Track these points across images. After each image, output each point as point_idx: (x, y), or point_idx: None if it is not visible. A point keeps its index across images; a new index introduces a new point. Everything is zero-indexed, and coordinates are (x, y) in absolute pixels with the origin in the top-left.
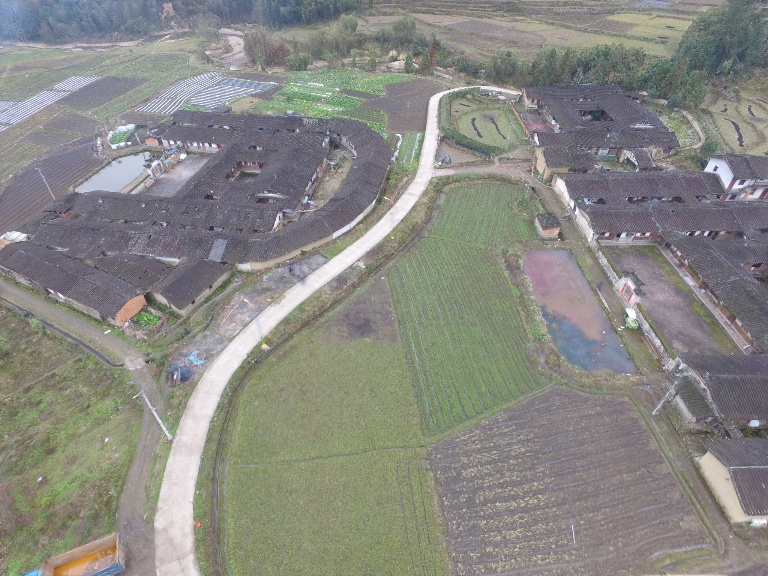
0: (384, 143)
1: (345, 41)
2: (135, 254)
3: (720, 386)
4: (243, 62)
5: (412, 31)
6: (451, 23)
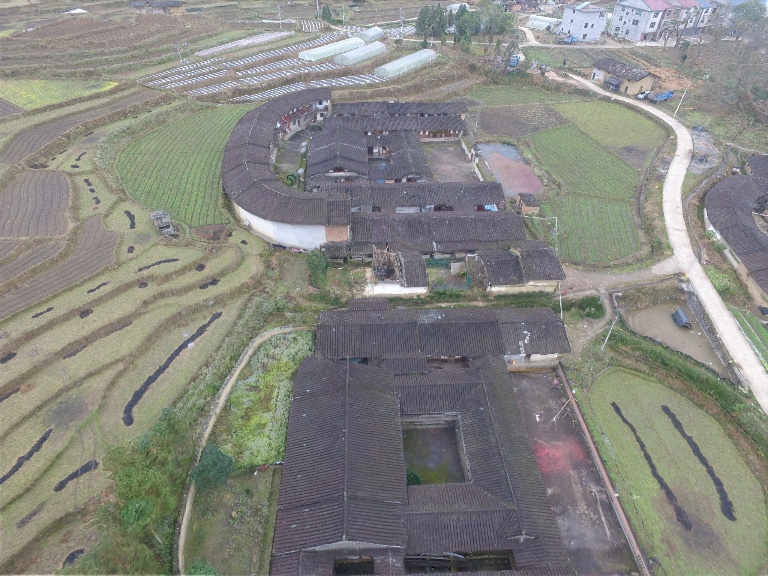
0: None
1: None
2: None
3: None
4: None
5: None
6: None
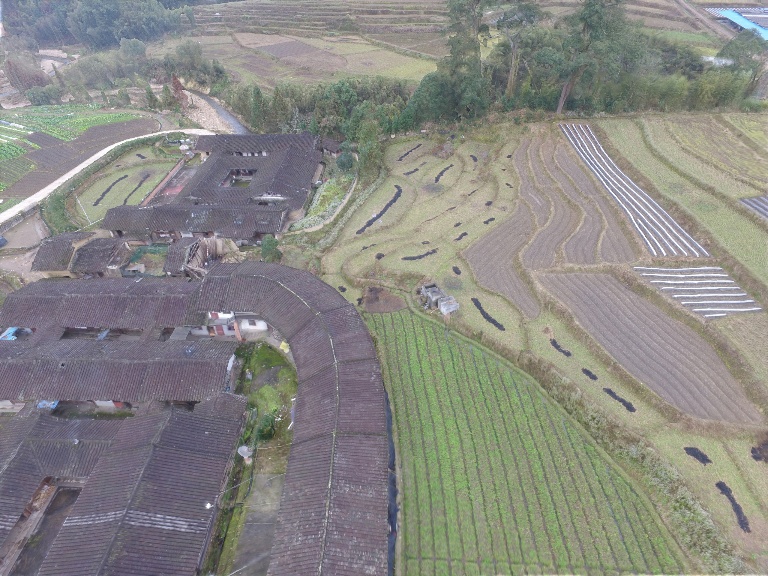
0: None
1: (106, 70)
2: None
3: None
4: (14, 92)
5: (195, 56)
6: (266, 44)
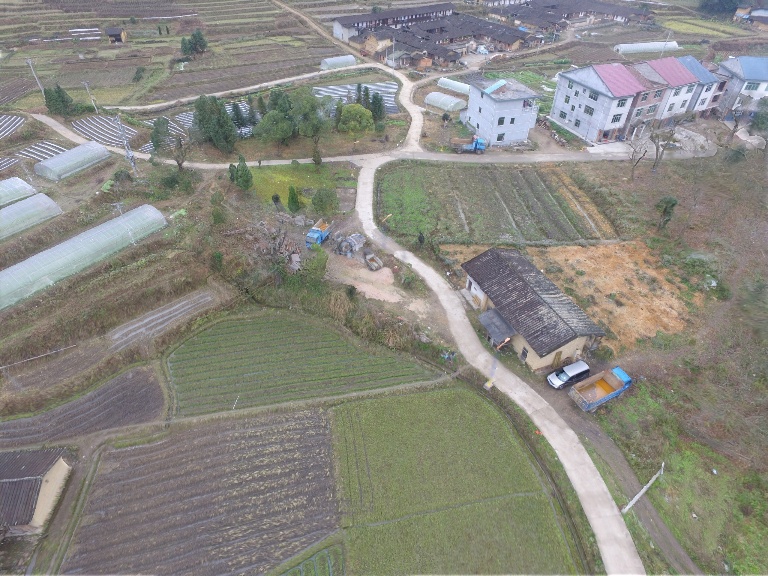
0: None
1: None
2: None
3: None
4: None
5: None
6: None
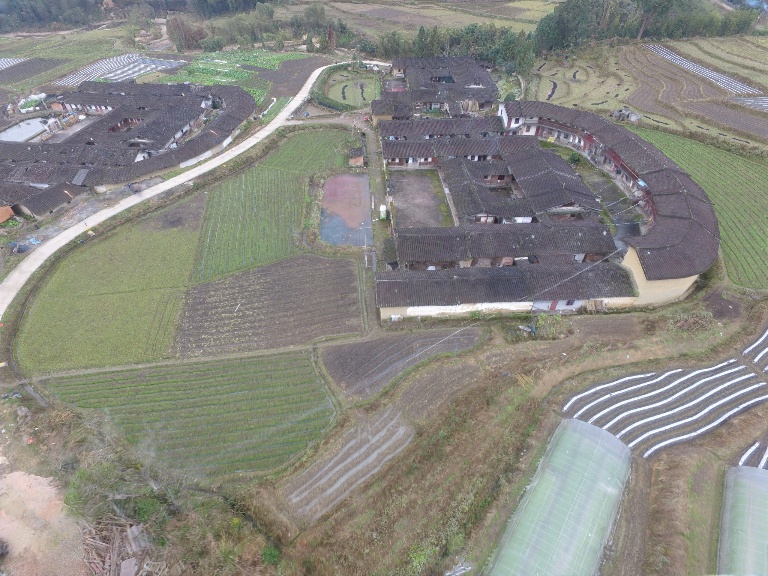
0: (252, 102)
1: (257, 25)
2: (13, 181)
3: (405, 241)
4: (168, 46)
5: (321, 16)
6: (364, 10)
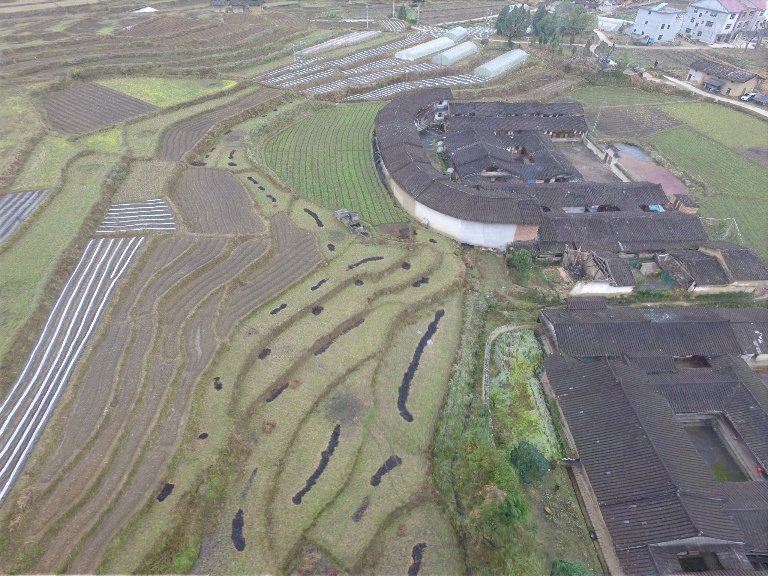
0: None
1: None
2: None
3: None
4: None
5: None
6: None
